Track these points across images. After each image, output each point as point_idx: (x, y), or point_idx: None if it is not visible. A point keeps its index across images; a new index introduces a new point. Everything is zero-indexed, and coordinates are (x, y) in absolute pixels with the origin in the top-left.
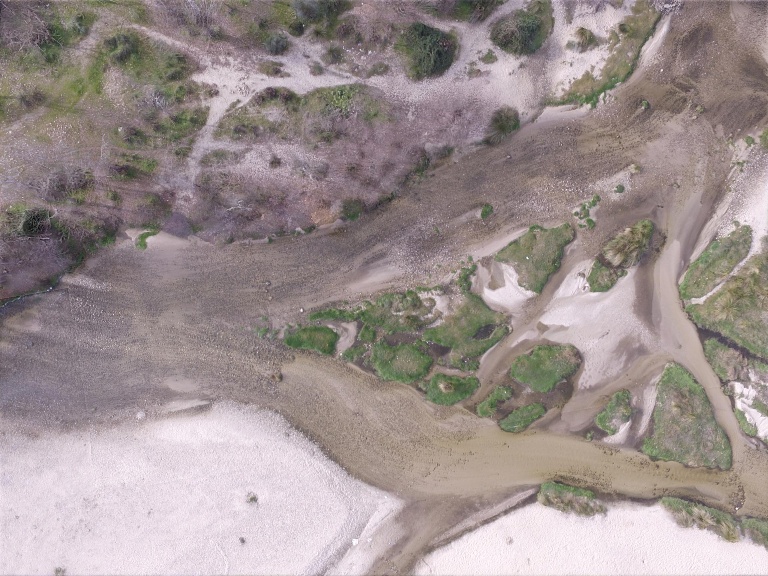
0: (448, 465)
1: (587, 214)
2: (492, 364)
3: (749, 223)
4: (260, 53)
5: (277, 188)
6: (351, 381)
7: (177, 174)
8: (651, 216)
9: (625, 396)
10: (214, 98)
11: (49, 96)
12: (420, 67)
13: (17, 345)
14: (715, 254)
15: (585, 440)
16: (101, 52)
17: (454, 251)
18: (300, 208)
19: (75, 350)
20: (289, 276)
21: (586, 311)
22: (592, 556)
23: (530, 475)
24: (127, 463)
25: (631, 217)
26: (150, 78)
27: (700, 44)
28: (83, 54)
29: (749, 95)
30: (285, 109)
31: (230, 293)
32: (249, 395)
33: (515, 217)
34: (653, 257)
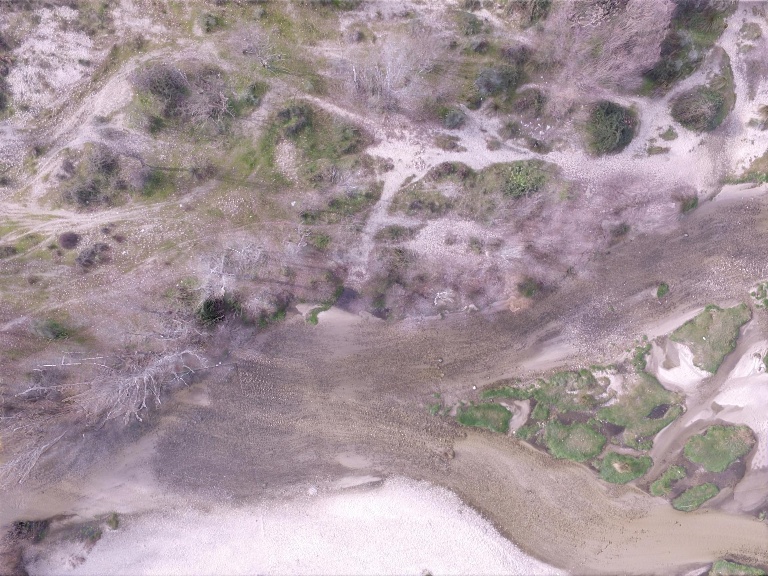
0: (620, 543)
1: (765, 294)
2: (665, 443)
3: None
4: (436, 127)
5: (452, 265)
6: (523, 459)
7: (350, 250)
8: None
9: None
10: (389, 172)
11: (221, 169)
12: (601, 144)
13: (185, 420)
14: None
15: (757, 519)
16: (274, 124)
17: (629, 330)
18: (475, 285)
19: (245, 425)
20: (461, 353)
21: (761, 392)
22: None
23: (701, 553)
24: (300, 540)
25: None
26: (324, 151)
27: None
28: (255, 126)
29: None
30: (462, 185)
31: (402, 370)
32: (421, 472)
33: (691, 296)
34: None
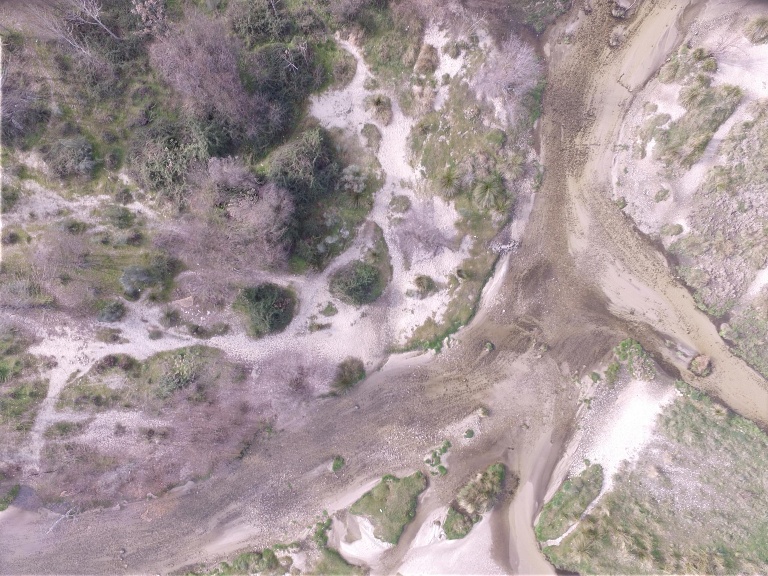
0: None
1: (438, 462)
2: None
3: (599, 461)
4: (97, 321)
5: (124, 456)
6: None
7: (21, 449)
8: (502, 459)
9: None
10: (53, 370)
11: None
12: (259, 327)
13: None
14: (567, 495)
15: None
16: None
17: (308, 506)
18: (149, 474)
19: None
20: (144, 542)
21: (443, 559)
22: None
23: None
24: None
25: (483, 461)
26: None
27: (540, 282)
28: None
29: (592, 331)
30: (126, 377)
31: (85, 564)
32: None
33: (367, 467)
34: (507, 500)
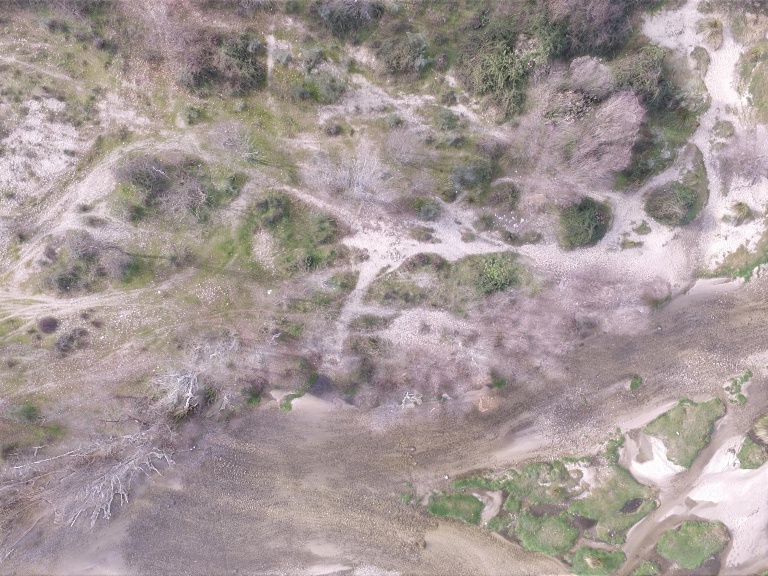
0: None
1: (739, 390)
2: (639, 538)
3: None
4: (412, 218)
5: (425, 355)
6: (495, 550)
7: (325, 338)
8: None
9: None
10: (364, 263)
11: (199, 257)
12: (574, 238)
13: (159, 503)
14: None
15: None
16: (252, 214)
17: (602, 422)
18: (448, 375)
19: (217, 510)
20: (434, 442)
21: (736, 488)
22: None
23: None
24: None
25: None
26: (301, 241)
27: None
28: (234, 215)
29: None
30: (436, 276)
31: (374, 457)
32: (392, 562)
33: (665, 389)
34: None
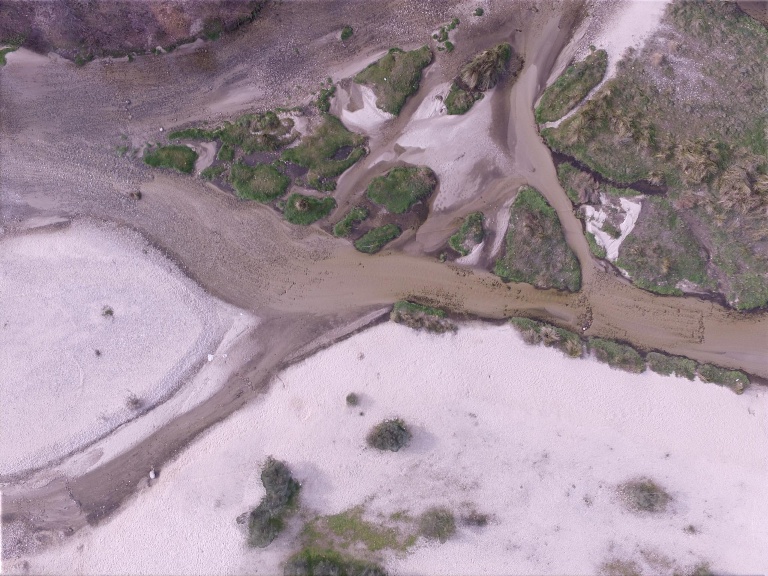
0: (304, 284)
1: (446, 36)
2: (349, 185)
3: (605, 47)
4: None
5: (136, 4)
6: (209, 200)
7: None
8: (509, 40)
9: (478, 217)
10: None
11: None
12: None
13: None
14: (570, 78)
15: (438, 261)
16: None
17: (314, 72)
18: (160, 26)
19: None
20: (149, 95)
21: (442, 133)
22: (440, 371)
23: (384, 295)
24: None
25: (489, 41)
26: None
27: None
28: None
29: None
30: None
31: (90, 111)
32: (108, 213)
33: (375, 39)
34: (510, 81)
